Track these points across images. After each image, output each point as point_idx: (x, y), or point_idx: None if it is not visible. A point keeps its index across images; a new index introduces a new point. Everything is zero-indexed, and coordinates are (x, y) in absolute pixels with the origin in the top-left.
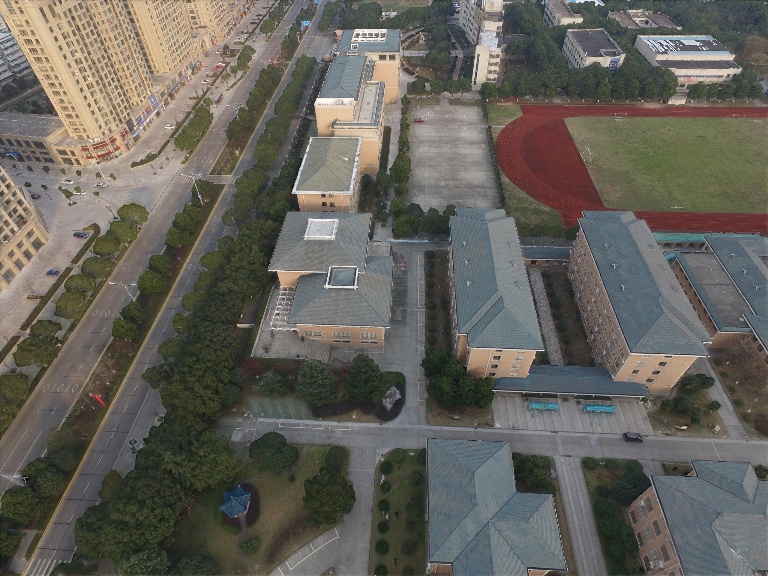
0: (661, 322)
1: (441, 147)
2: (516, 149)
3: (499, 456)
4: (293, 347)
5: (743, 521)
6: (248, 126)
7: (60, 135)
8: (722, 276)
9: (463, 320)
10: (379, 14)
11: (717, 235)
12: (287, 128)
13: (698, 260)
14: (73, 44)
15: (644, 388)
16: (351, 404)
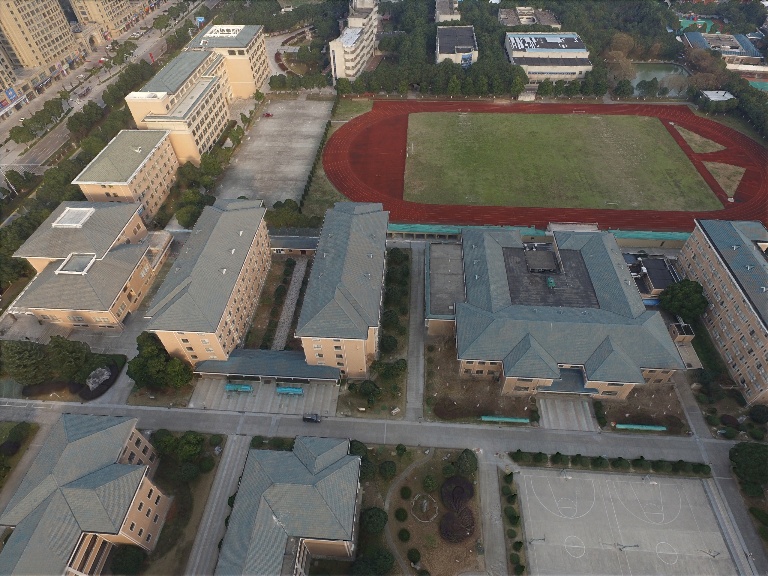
0: (329, 307)
1: (276, 141)
2: (347, 143)
3: (113, 430)
4: (29, 330)
5: (292, 491)
6: (95, 119)
7: None
8: (457, 266)
9: (153, 304)
10: (275, 10)
11: (493, 228)
12: (129, 121)
13: (444, 251)
14: None
15: (336, 372)
16: (60, 384)
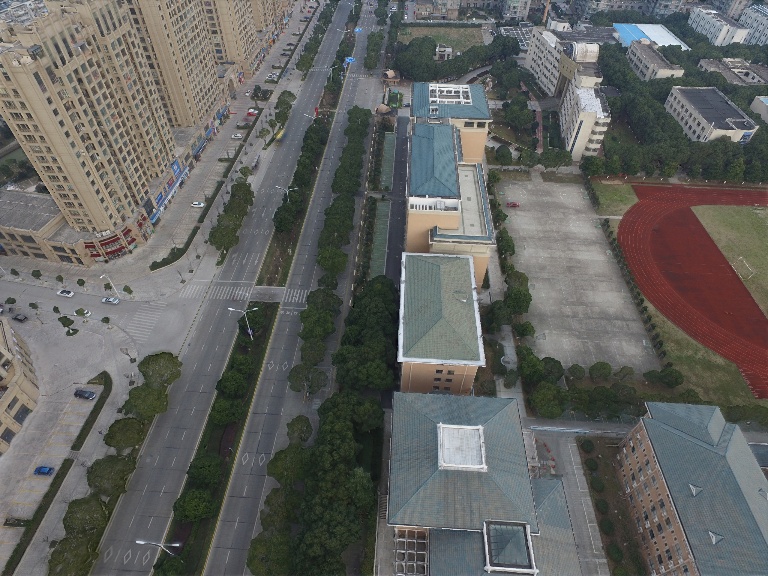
0: None
1: (551, 248)
2: (647, 255)
3: None
4: None
5: None
6: (300, 210)
7: (56, 225)
8: None
9: None
10: (434, 51)
11: None
12: (352, 217)
13: None
14: (79, 116)
15: None
16: None
